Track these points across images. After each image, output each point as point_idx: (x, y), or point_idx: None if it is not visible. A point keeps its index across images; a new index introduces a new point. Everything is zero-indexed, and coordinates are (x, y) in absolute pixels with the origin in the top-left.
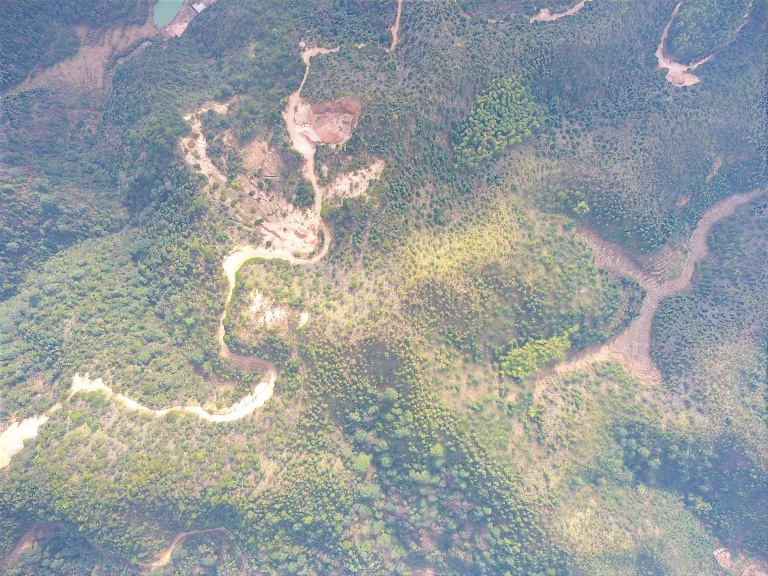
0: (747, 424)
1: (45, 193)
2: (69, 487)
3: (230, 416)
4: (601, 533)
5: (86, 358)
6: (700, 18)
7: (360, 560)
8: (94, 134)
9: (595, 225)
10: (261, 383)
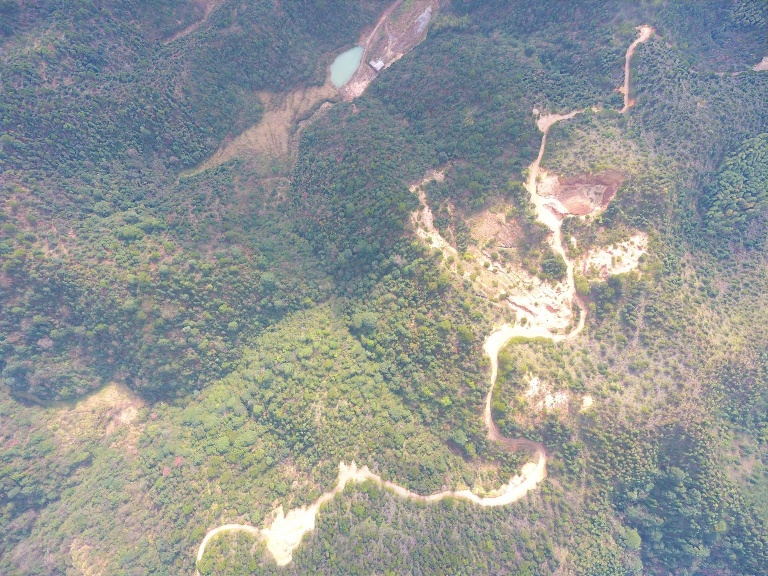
0: None
1: (263, 271)
2: None
3: (501, 499)
4: None
5: (347, 445)
6: None
7: None
8: (284, 201)
9: None
10: (528, 463)
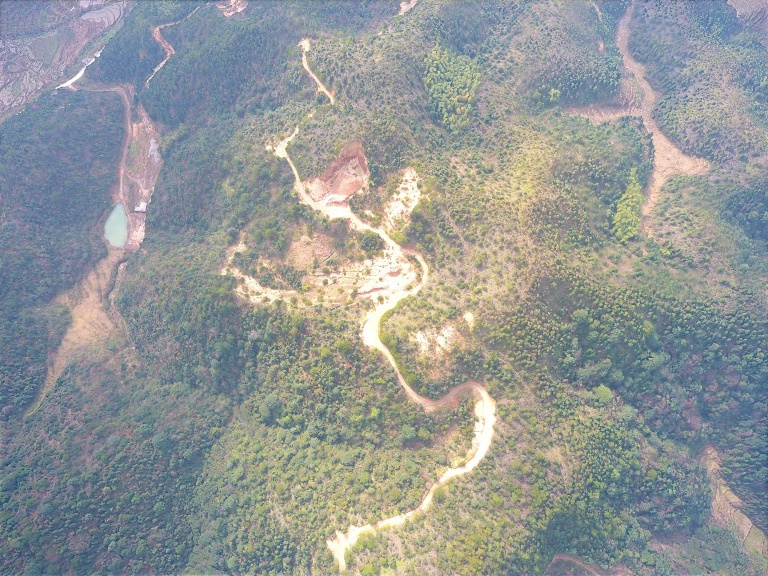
0: None
1: (151, 437)
2: None
3: (479, 453)
4: None
5: (322, 522)
6: None
7: None
8: (139, 367)
9: (570, 101)
10: (476, 405)
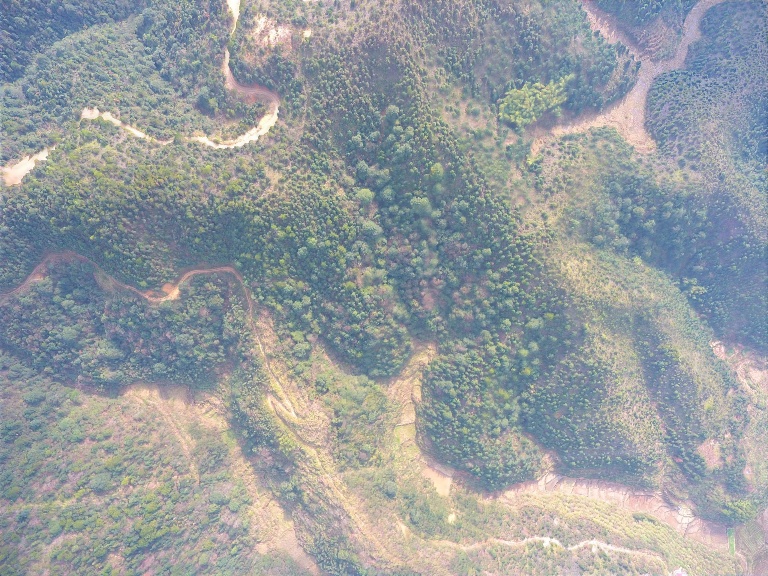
0: (740, 184)
1: None
2: (80, 185)
3: None
4: (598, 282)
5: (94, 95)
6: None
7: (363, 307)
8: None
9: None
10: (265, 116)
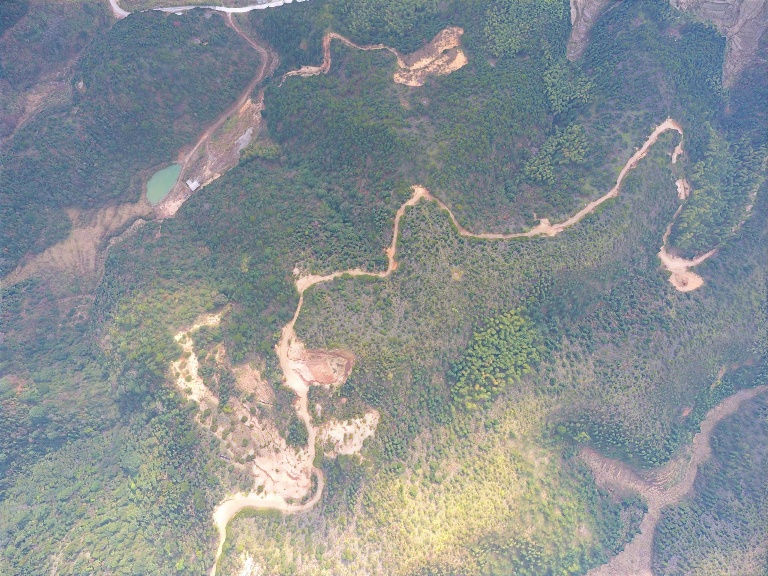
0: None
1: (34, 404)
2: None
3: None
4: None
5: None
6: (704, 215)
7: None
8: (85, 320)
9: (596, 446)
10: None
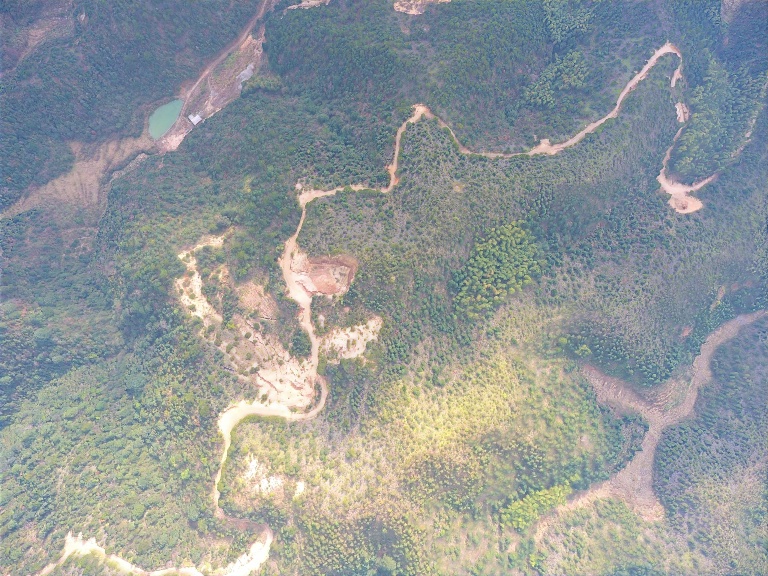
0: (752, 565)
1: (39, 327)
2: None
3: None
4: None
5: (79, 515)
6: (703, 140)
7: None
8: (89, 252)
9: (597, 363)
10: (257, 542)
